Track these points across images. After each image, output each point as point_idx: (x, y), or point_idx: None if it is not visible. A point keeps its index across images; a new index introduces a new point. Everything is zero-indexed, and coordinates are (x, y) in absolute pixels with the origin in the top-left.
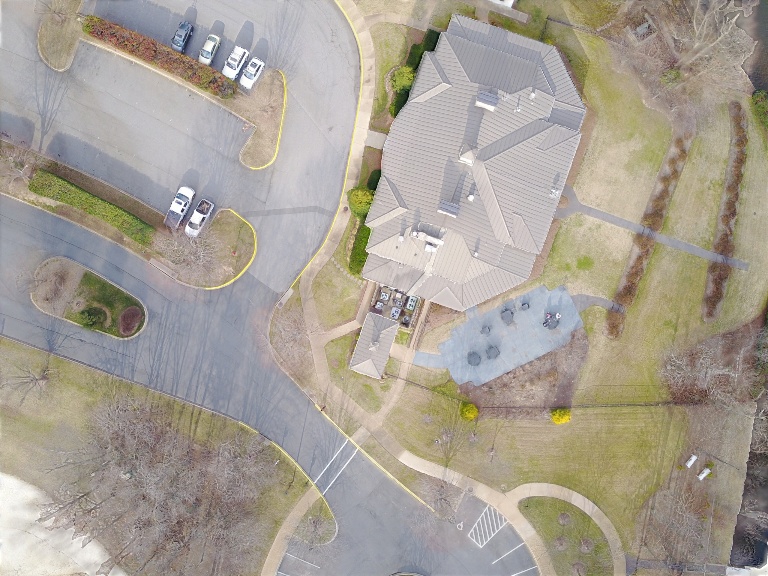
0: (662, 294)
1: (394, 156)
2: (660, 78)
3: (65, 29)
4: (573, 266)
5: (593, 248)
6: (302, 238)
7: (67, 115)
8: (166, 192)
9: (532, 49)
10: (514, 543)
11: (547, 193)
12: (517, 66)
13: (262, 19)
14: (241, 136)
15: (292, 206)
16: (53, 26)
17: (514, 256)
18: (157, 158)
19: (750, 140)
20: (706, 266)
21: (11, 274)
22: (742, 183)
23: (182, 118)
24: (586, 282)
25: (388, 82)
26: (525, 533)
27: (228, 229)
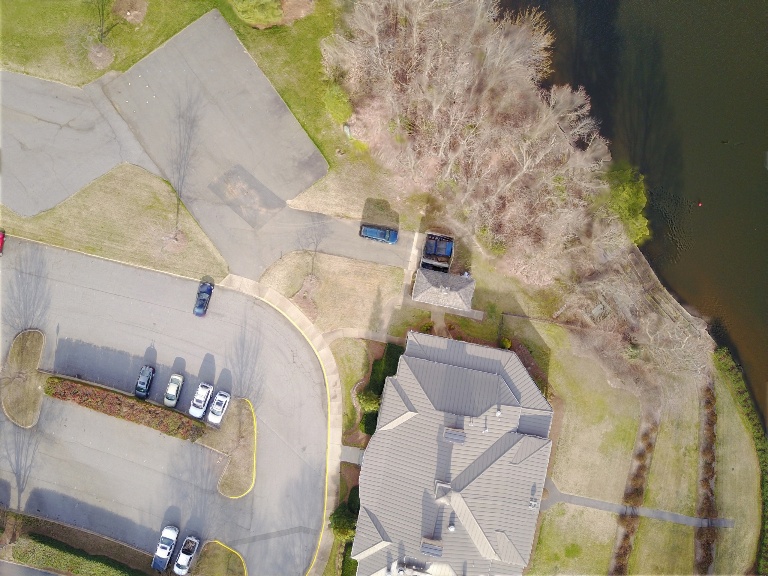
0: (653, 567)
1: (371, 486)
2: (622, 353)
3: (27, 388)
4: (562, 555)
5: (579, 534)
6: (291, 560)
7: (41, 470)
8: (150, 532)
9: (492, 358)
10: None
11: (526, 505)
12: (479, 382)
13: (222, 350)
14: (217, 467)
15: (277, 530)
16: (15, 386)
17: (502, 567)
18: (136, 500)
19: (718, 396)
20: (692, 533)
21: None
22: (716, 441)
23: (156, 457)
24: (577, 569)
25: (355, 398)
26: None
27: (216, 561)
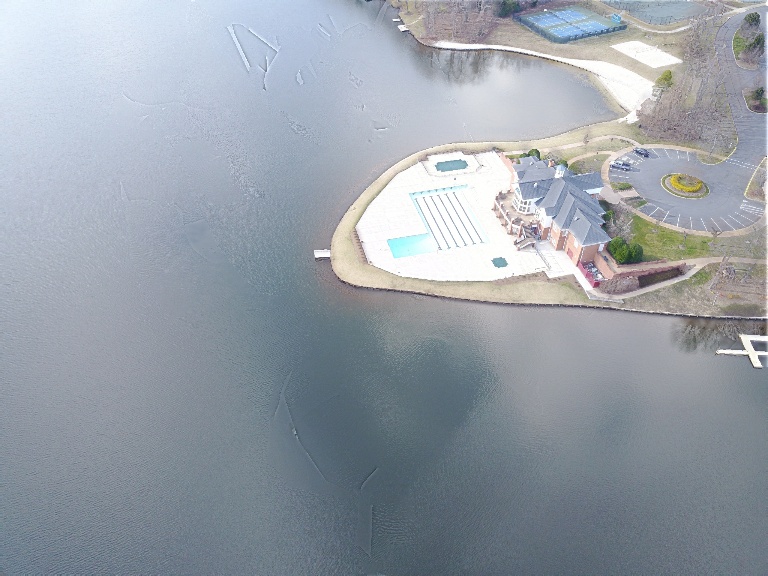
0: None
1: None
2: None
3: None
4: None
5: None
6: None
7: None
8: None
9: None
10: (752, 219)
11: None
12: None
13: None
14: None
15: None
16: None
17: None
18: None
19: None
20: None
21: (751, 84)
22: None
23: None
24: None
25: None
26: (761, 222)
27: None
